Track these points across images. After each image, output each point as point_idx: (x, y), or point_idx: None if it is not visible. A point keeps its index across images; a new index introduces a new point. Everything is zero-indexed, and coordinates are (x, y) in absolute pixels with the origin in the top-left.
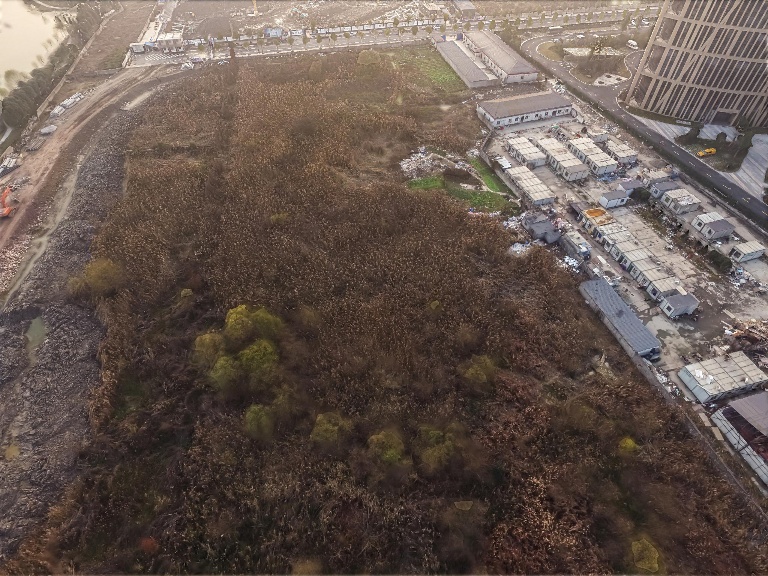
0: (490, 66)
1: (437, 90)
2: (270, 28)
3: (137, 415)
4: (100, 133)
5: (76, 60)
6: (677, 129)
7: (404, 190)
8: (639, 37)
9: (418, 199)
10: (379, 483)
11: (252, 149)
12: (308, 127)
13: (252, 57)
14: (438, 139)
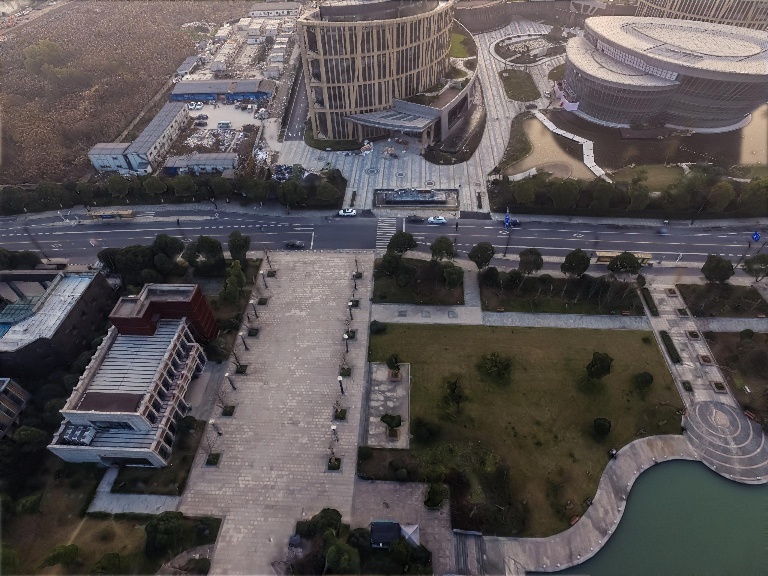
0: None
1: (247, 1)
2: None
3: (4, 68)
4: None
5: None
6: None
7: None
8: None
9: None
10: (50, 79)
11: None
12: (156, 7)
13: None
14: None
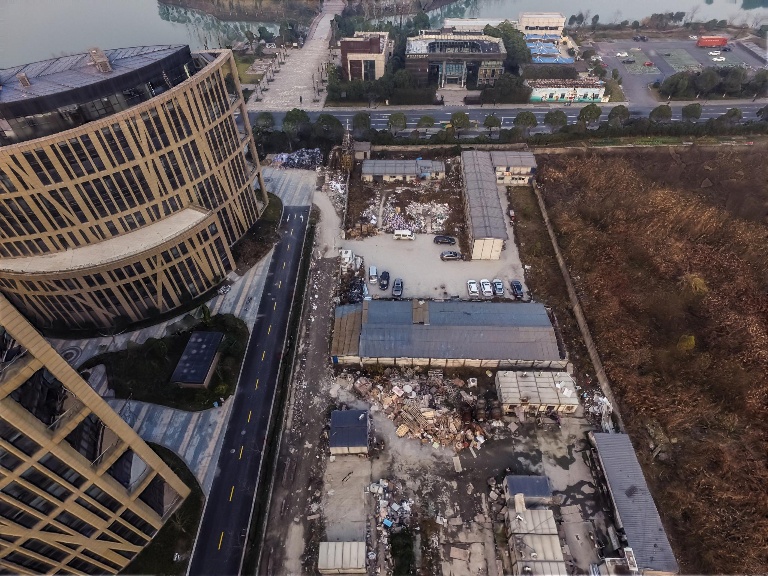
0: None
1: None
2: None
3: None
4: None
5: None
6: None
7: None
8: None
9: None
10: None
11: None
12: None
13: None
14: None
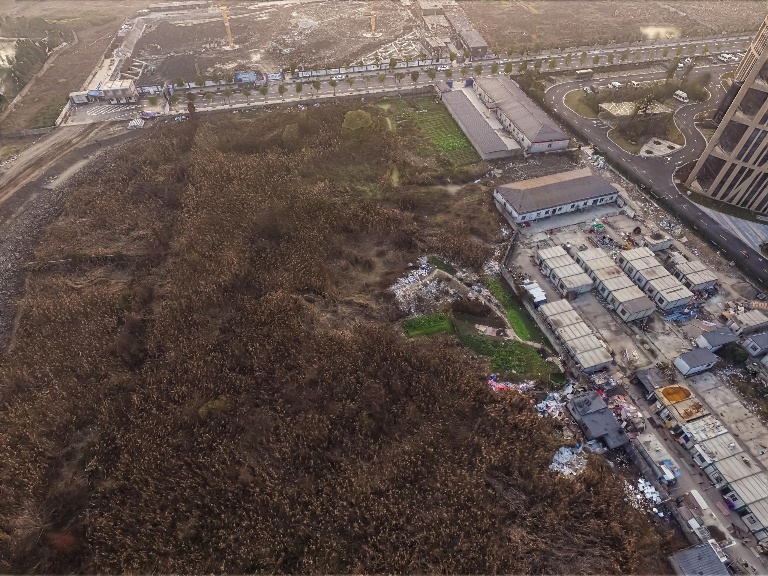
0: (508, 126)
1: (443, 163)
2: (241, 72)
3: None
4: (8, 226)
5: (3, 114)
6: (760, 230)
7: (398, 346)
8: (688, 86)
9: (417, 362)
10: None
11: (195, 265)
12: (273, 228)
13: (216, 111)
14: (445, 244)
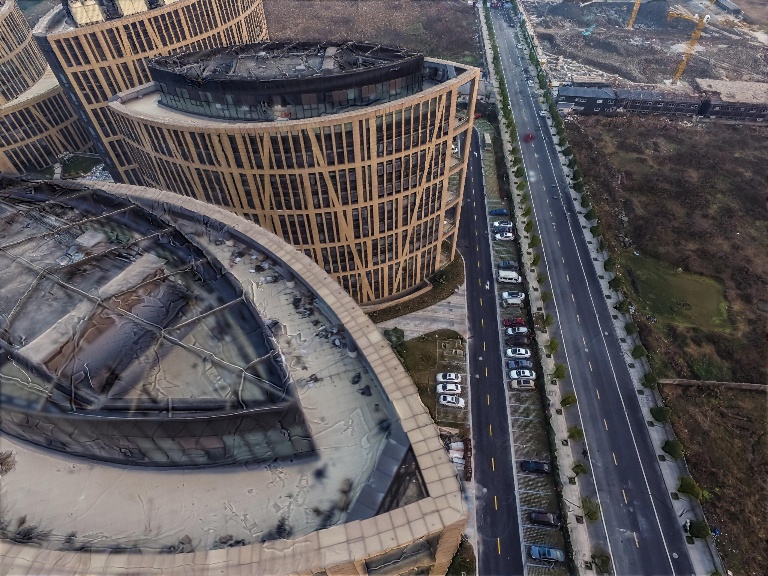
0: None
1: None
2: None
3: None
4: None
5: None
6: None
7: None
8: None
9: None
10: None
11: None
12: None
13: None
14: None
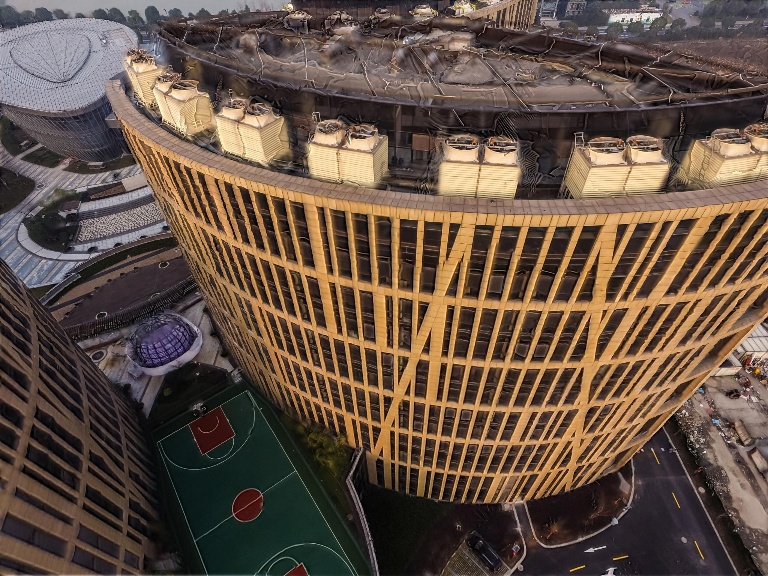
0: None
1: None
2: None
3: None
4: None
5: None
6: None
7: None
8: None
9: None
10: None
11: None
12: None
13: None
14: None
